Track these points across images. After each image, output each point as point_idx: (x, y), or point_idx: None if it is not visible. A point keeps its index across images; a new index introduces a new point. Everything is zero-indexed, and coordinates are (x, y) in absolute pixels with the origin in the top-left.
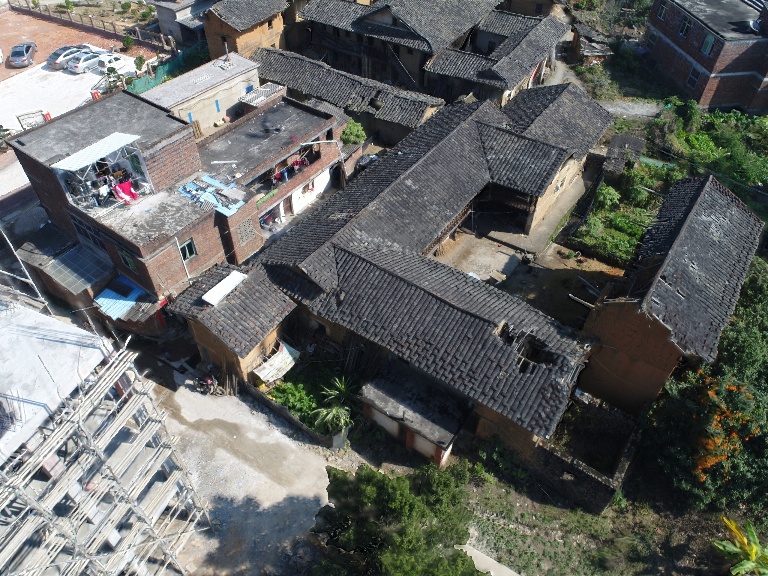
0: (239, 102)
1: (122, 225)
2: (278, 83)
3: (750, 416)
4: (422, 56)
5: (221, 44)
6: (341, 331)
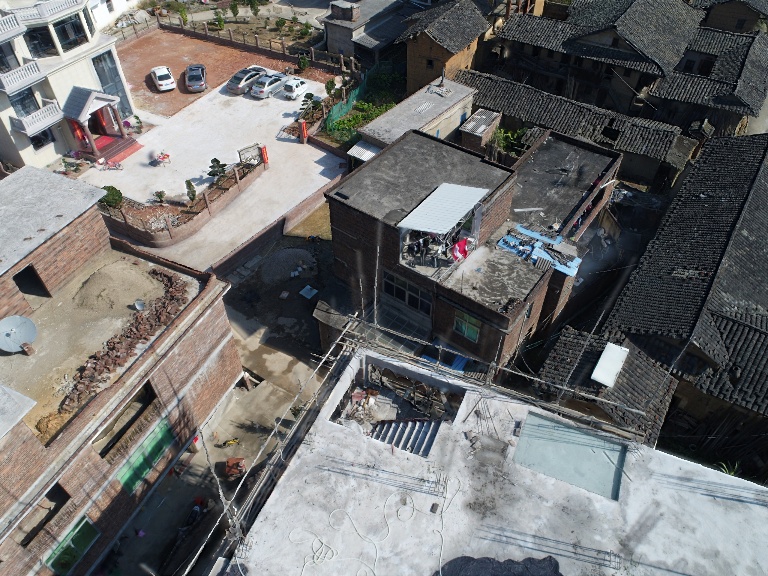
0: (453, 131)
1: (459, 288)
2: (491, 109)
3: None
4: (639, 78)
5: (425, 67)
6: (708, 406)
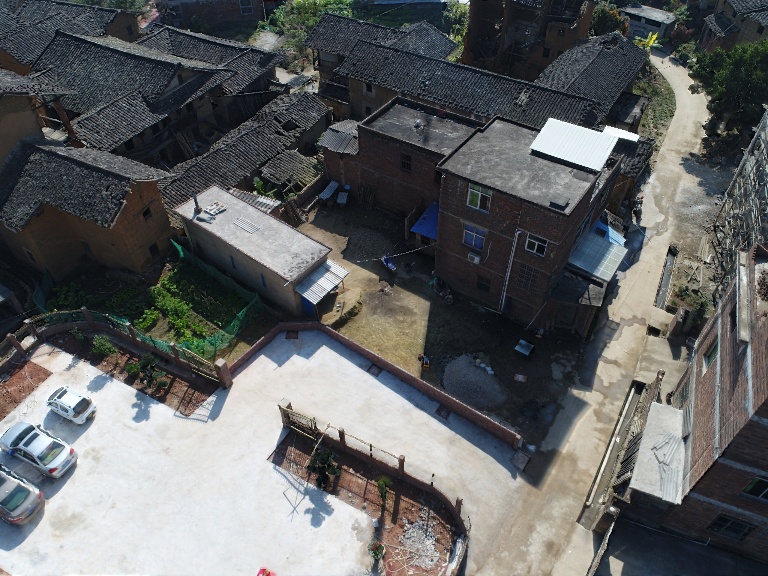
0: None
1: None
2: None
3: (616, 8)
4: None
5: (144, 223)
6: None
